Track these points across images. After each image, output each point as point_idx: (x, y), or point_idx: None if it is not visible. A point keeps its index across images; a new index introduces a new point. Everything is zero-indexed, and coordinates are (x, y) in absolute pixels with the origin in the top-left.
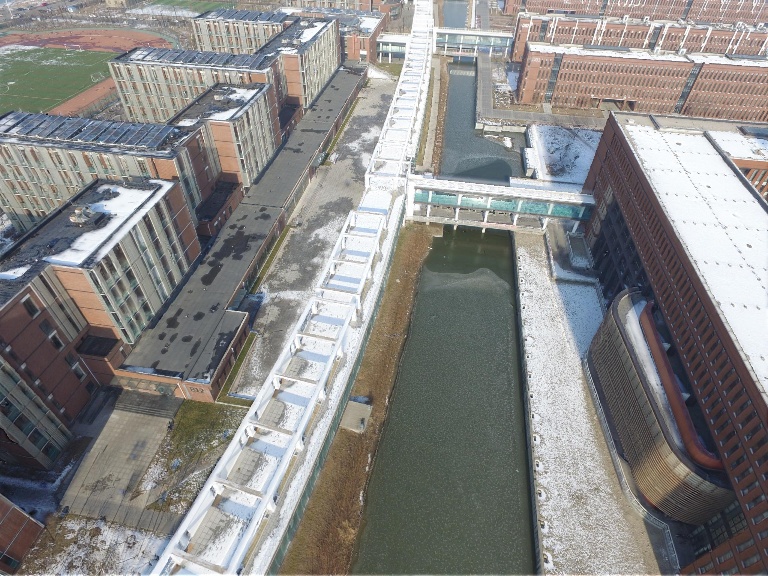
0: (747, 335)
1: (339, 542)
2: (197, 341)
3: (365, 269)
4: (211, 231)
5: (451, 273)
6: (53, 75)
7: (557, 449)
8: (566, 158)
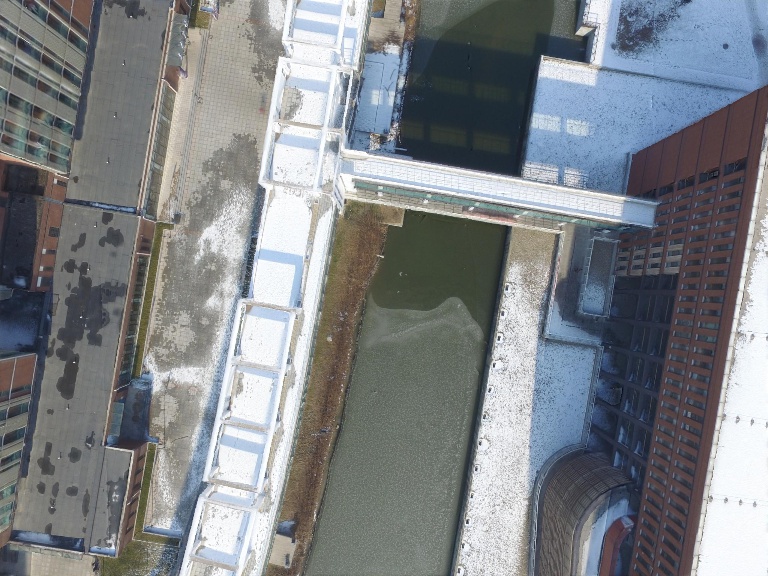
0: None
1: None
2: (85, 494)
3: (266, 444)
4: None
5: (406, 310)
6: None
7: None
8: None
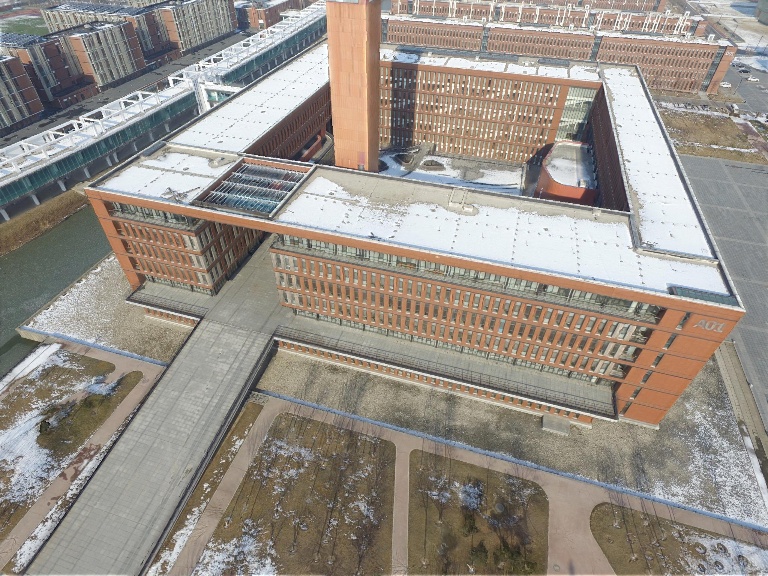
0: None
1: (38, 228)
2: None
3: None
4: (62, 105)
5: None
6: (38, 33)
7: None
8: None
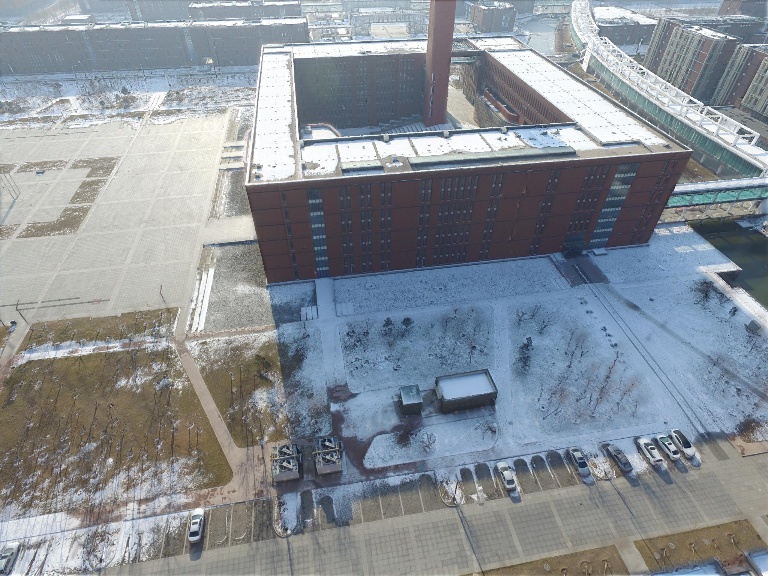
0: None
1: None
2: None
3: None
4: None
5: None
6: None
7: None
8: (720, 314)
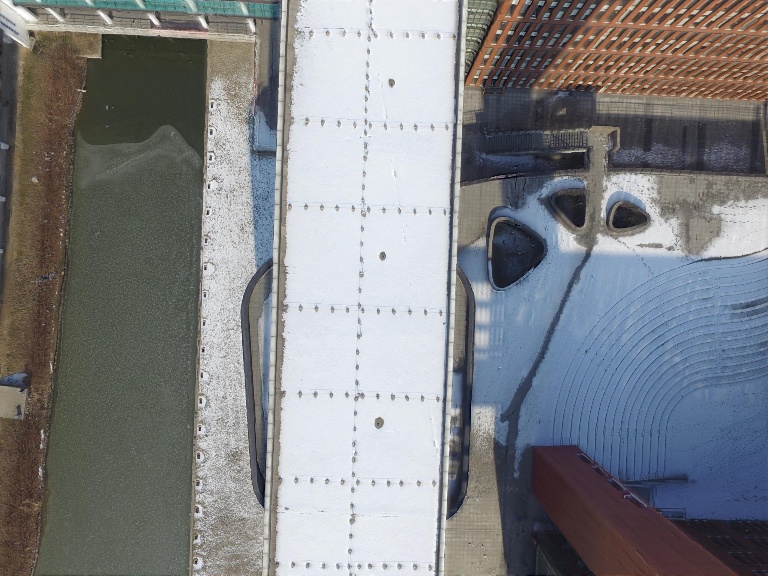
0: (294, 446)
1: (26, 515)
2: None
3: None
4: None
5: (117, 144)
6: None
7: (221, 410)
8: None
